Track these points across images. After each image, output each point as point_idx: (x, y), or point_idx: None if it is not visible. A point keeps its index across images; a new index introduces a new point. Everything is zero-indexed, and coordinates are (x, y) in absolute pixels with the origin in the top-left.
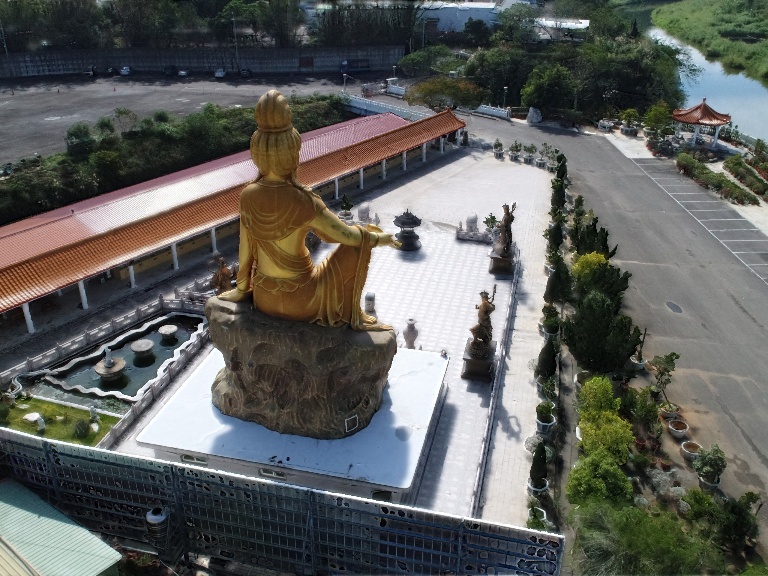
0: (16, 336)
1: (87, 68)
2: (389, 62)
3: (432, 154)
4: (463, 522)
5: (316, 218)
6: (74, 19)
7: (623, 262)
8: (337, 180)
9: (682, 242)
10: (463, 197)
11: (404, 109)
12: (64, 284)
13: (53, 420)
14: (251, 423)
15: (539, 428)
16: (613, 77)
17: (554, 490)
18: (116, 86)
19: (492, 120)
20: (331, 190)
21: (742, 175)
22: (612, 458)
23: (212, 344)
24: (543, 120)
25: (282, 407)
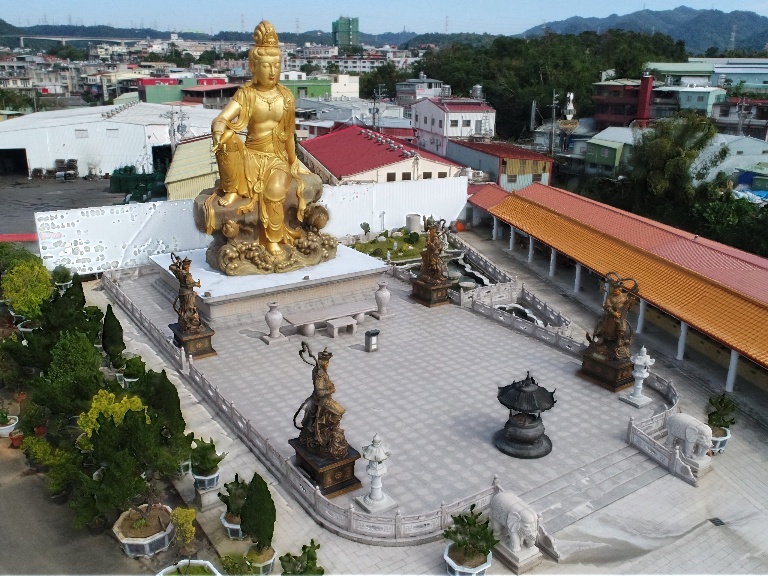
0: None
1: None
2: None
3: None
4: None
5: None
6: None
7: None
8: None
9: None
10: None
11: None
12: (536, 235)
13: (399, 251)
14: None
15: None
16: None
17: None
18: None
19: None
20: None
21: None
22: None
23: None
24: None
25: None
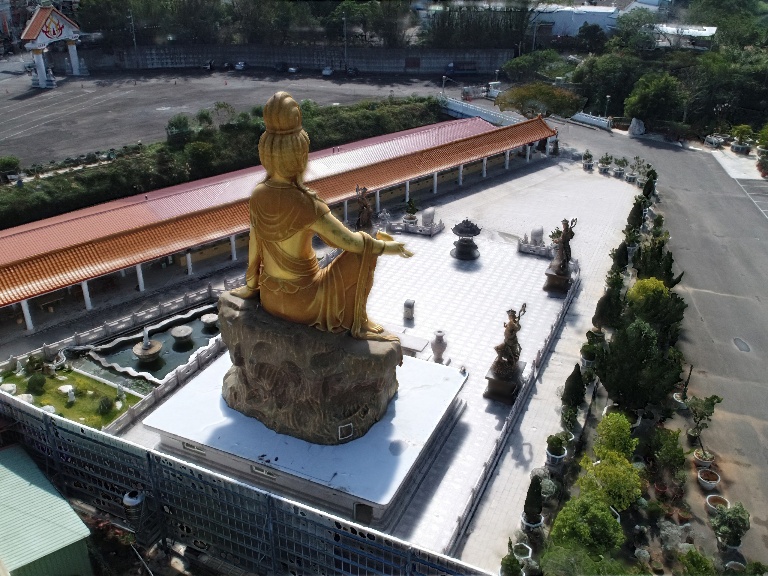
0: (75, 311)
1: (205, 62)
2: (497, 65)
3: (517, 162)
4: (410, 549)
5: (317, 222)
6: (197, 15)
7: (696, 290)
8: (408, 183)
9: None
10: (538, 208)
11: (499, 114)
12: (121, 266)
13: (83, 394)
14: (252, 419)
15: (548, 459)
16: (734, 89)
17: (551, 528)
18: (228, 80)
19: (591, 130)
20: (403, 193)
21: None
22: (611, 502)
23: None
24: (646, 132)
25: (280, 407)
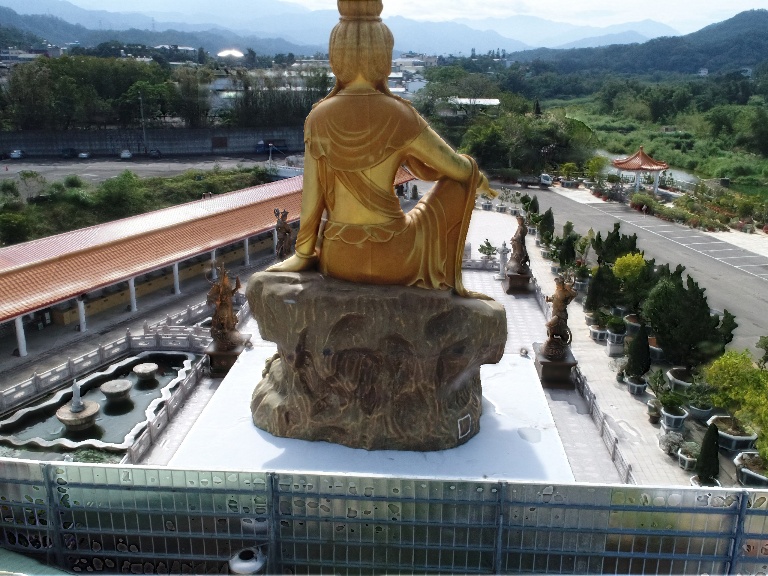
0: None
1: None
2: None
3: None
4: (746, 496)
5: (420, 135)
6: None
7: None
8: None
9: (681, 261)
10: None
11: None
12: None
13: None
14: (321, 443)
15: (669, 424)
16: (534, 145)
17: None
18: None
19: None
20: (292, 236)
21: (698, 210)
22: None
23: (209, 379)
24: None
25: (368, 412)
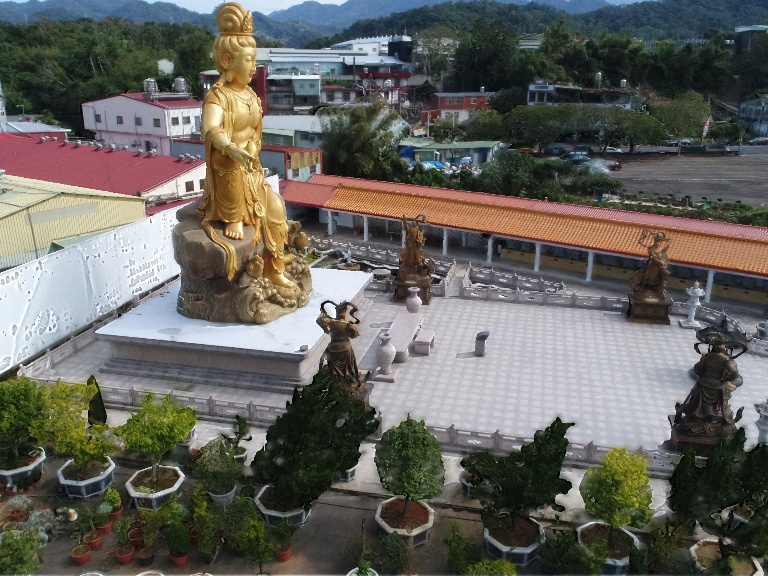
0: (396, 244)
1: None
2: None
3: None
4: None
5: None
6: None
7: None
8: None
9: None
10: None
11: None
12: None
13: None
14: None
15: None
16: None
17: None
18: None
19: None
20: None
21: None
22: None
23: (393, 294)
24: None
25: None
